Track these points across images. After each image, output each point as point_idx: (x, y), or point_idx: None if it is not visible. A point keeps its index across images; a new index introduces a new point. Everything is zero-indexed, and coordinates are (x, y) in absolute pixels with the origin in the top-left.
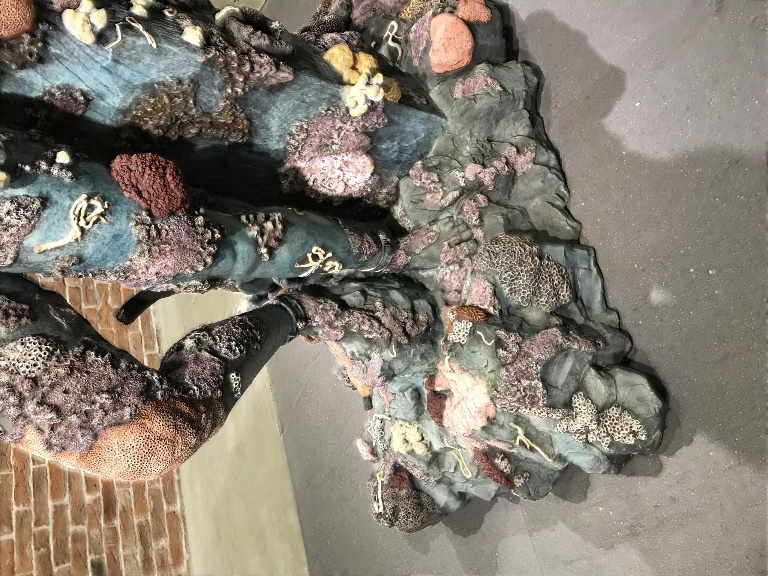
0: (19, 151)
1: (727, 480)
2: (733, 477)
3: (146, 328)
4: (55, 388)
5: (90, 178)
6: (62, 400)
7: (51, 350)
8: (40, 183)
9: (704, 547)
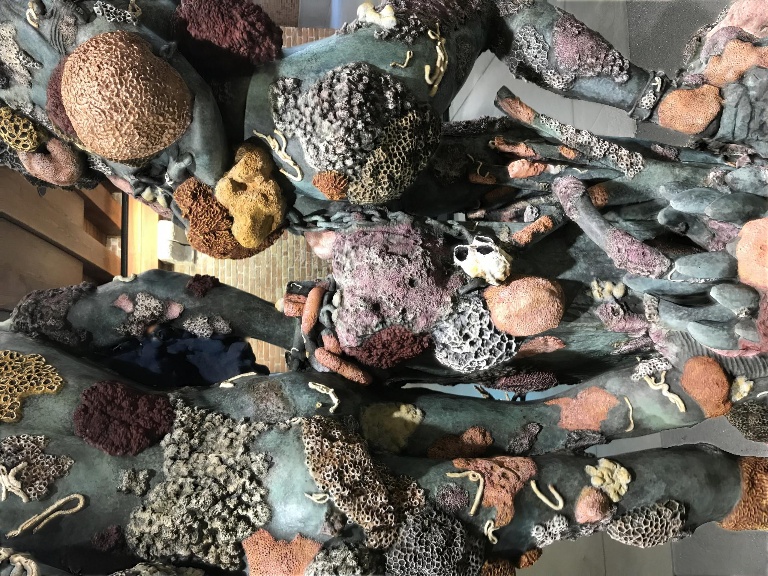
0: None
1: (725, 0)
2: (724, 3)
3: None
4: None
5: None
6: None
7: None
8: None
9: None
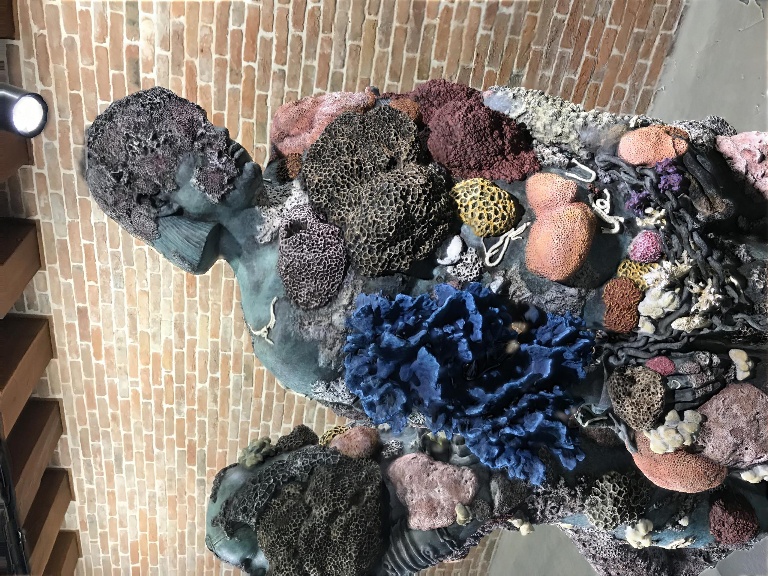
0: (660, 517)
1: None
2: None
3: (675, 1)
4: (614, 569)
5: (694, 526)
6: (614, 575)
7: (620, 554)
8: (662, 534)
9: None
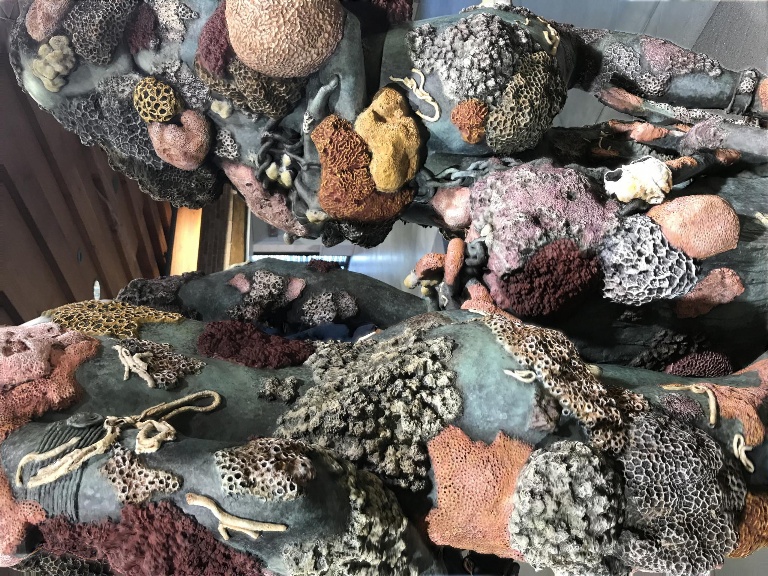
0: None
1: None
2: None
3: None
4: None
5: None
6: None
7: None
8: None
9: (763, 59)
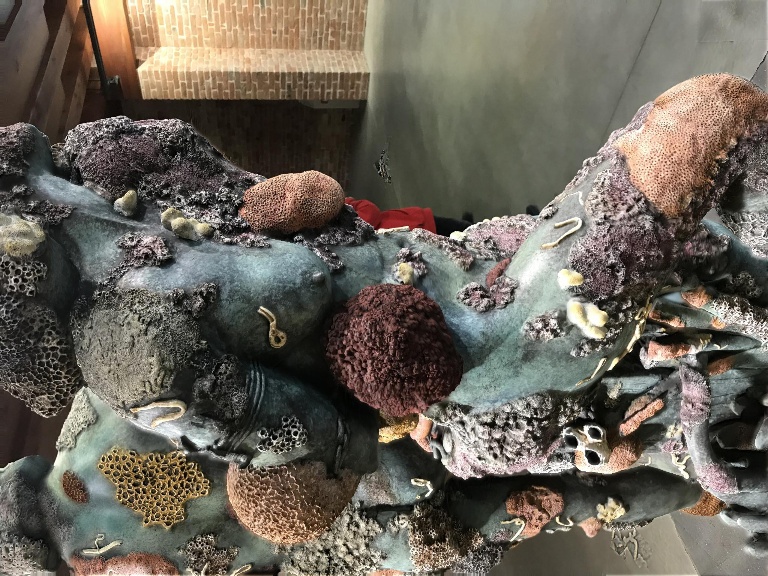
0: None
1: None
2: None
3: None
4: None
5: None
6: None
7: None
8: None
9: None
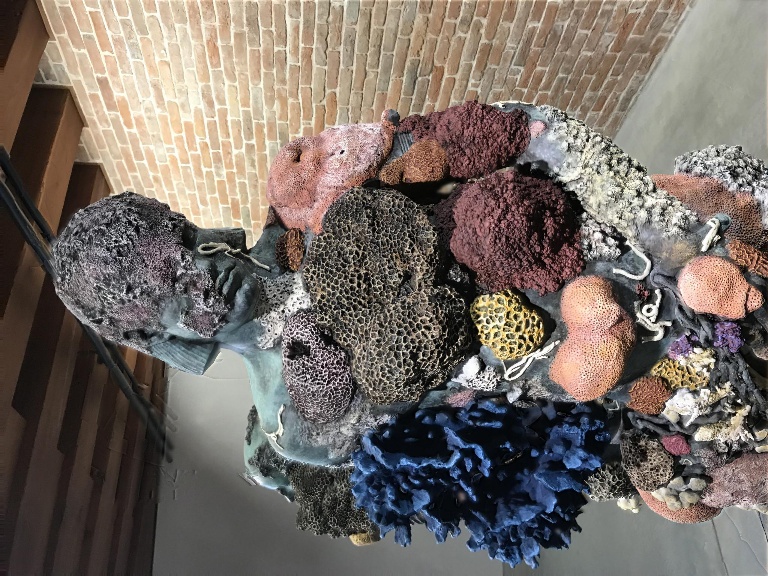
0: None
1: None
2: None
3: None
4: None
5: None
6: None
7: None
8: None
9: None
